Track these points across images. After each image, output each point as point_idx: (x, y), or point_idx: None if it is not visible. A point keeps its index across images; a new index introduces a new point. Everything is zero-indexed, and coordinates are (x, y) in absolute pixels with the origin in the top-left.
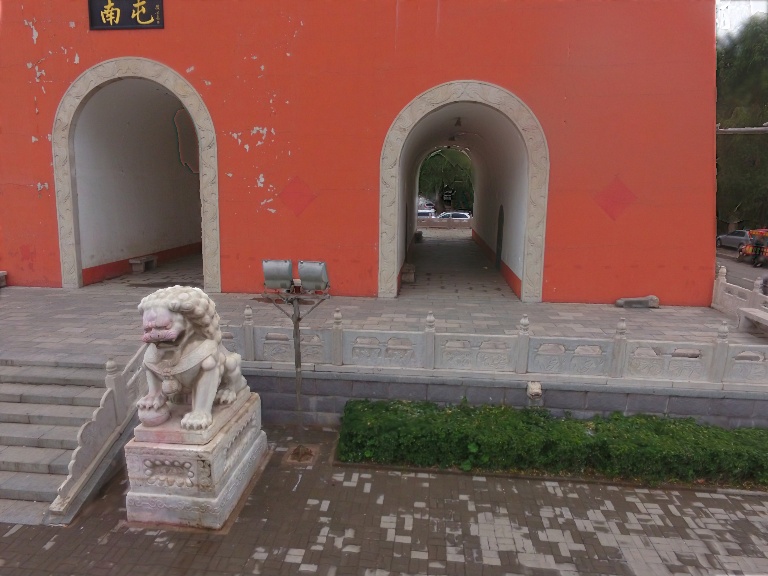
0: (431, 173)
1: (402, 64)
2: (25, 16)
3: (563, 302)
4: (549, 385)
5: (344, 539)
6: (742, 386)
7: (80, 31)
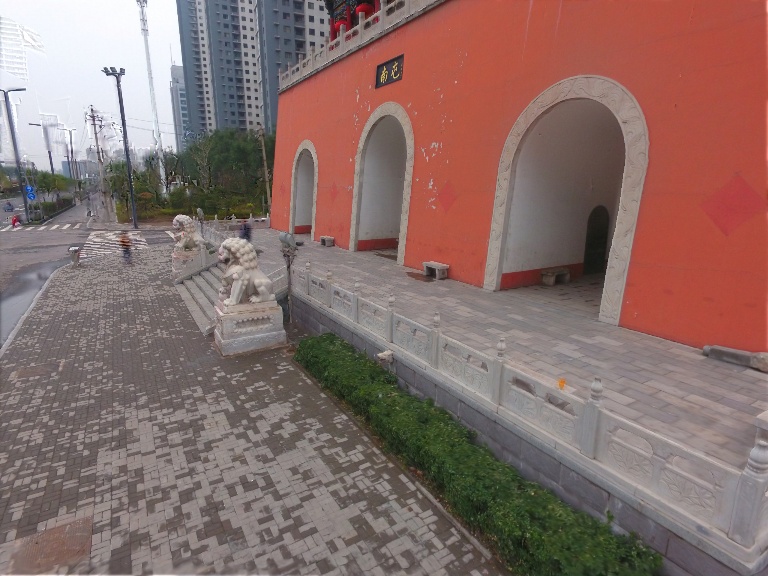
0: None
1: (526, 72)
2: (356, 87)
3: (643, 332)
4: (397, 356)
5: (238, 379)
6: (512, 416)
7: (372, 90)
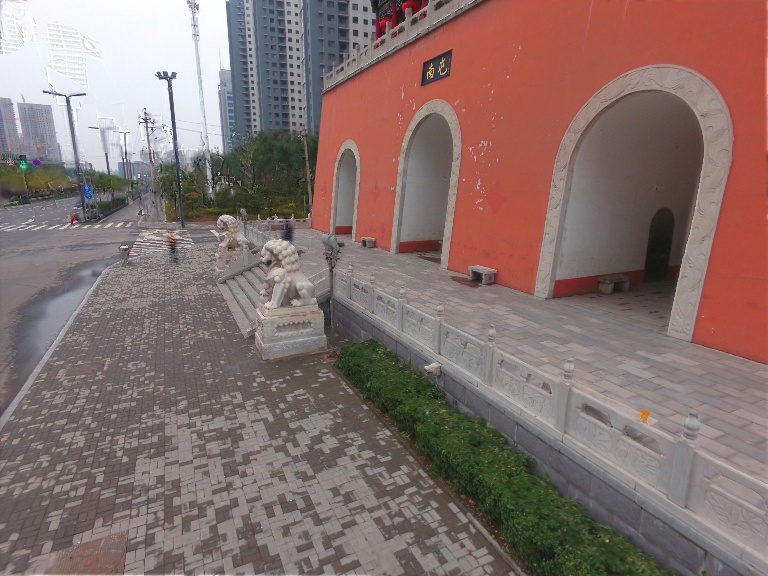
0: None
1: (587, 64)
2: (401, 85)
3: (722, 350)
4: (445, 370)
5: None
6: (580, 447)
7: (418, 88)
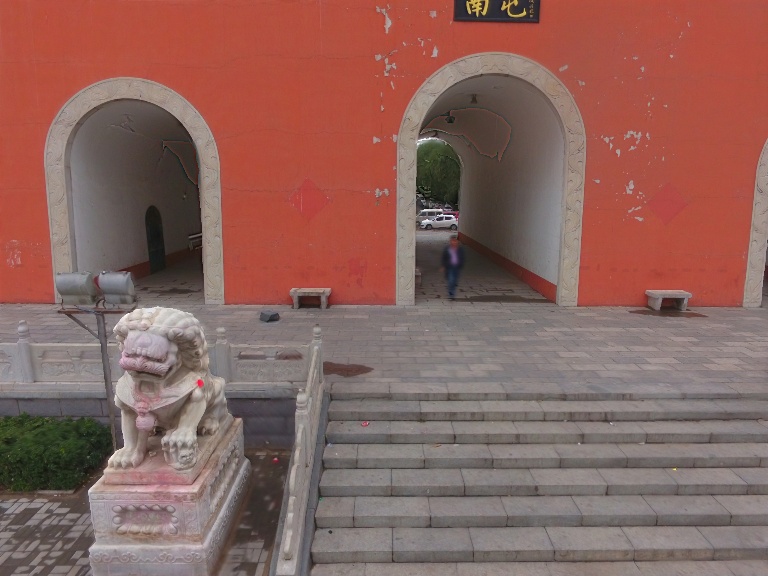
0: (453, 176)
1: None
2: (377, 2)
3: None
4: None
5: None
6: None
7: (442, 22)
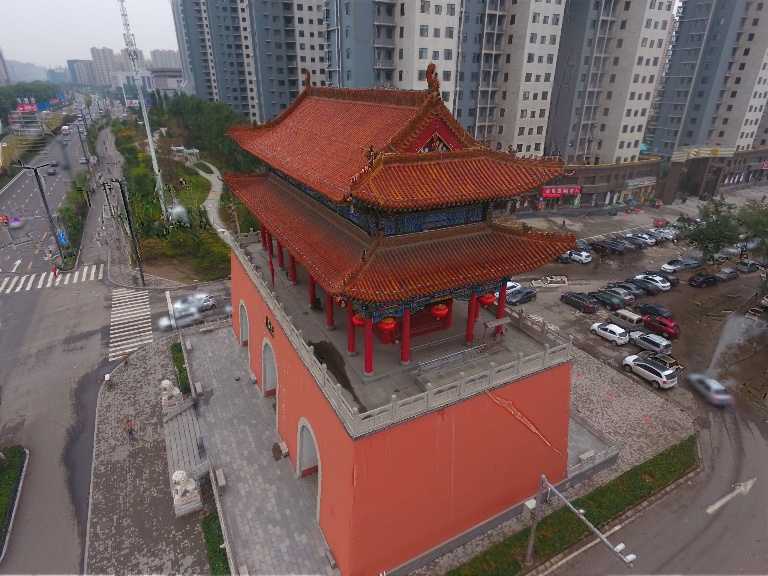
0: None
1: None
2: None
3: None
4: None
5: None
6: None
7: None
